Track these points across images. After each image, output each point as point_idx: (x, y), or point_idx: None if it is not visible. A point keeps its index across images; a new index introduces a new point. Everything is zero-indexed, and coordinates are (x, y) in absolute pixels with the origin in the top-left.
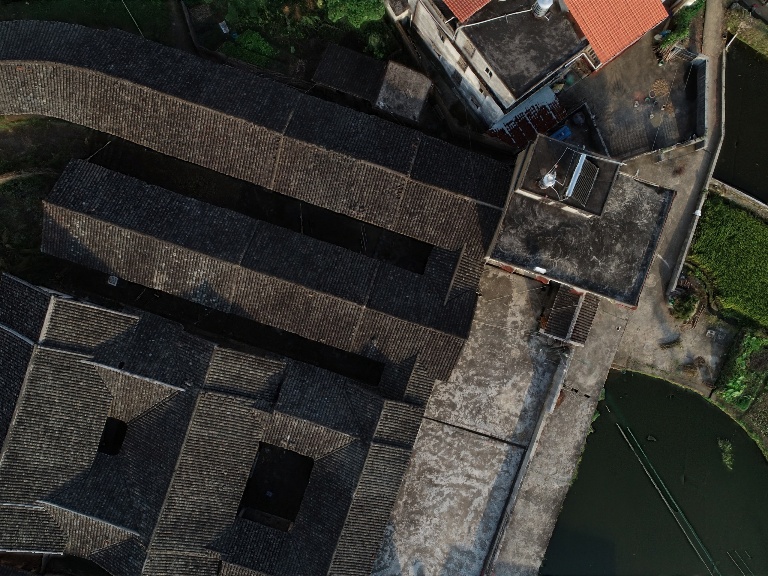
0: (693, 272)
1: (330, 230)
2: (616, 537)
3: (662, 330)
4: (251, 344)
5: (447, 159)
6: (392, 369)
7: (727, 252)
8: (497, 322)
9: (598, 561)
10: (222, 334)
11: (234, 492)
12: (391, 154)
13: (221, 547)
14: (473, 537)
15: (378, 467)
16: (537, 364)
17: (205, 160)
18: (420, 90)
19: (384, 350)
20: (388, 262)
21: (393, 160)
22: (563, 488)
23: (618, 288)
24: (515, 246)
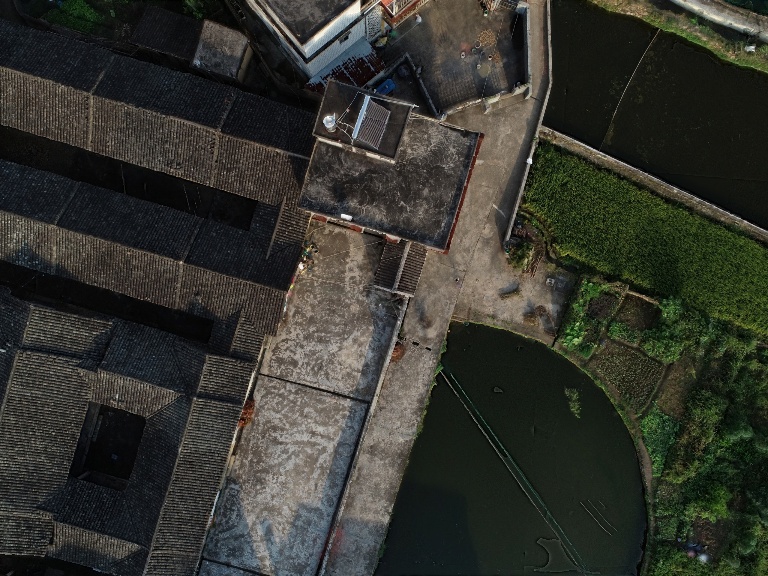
0: (530, 221)
1: (164, 192)
2: (466, 490)
3: (501, 280)
4: (89, 308)
5: (262, 114)
6: (220, 325)
7: (560, 199)
8: (335, 278)
9: (449, 515)
10: (60, 299)
11: (64, 452)
12: (202, 110)
13: (52, 507)
14: (320, 494)
15: (205, 422)
16: (377, 319)
17: (21, 123)
18: (236, 47)
19: (210, 306)
20: (223, 222)
21: (204, 115)
22: (408, 442)
23: (427, 233)
24: (322, 195)
